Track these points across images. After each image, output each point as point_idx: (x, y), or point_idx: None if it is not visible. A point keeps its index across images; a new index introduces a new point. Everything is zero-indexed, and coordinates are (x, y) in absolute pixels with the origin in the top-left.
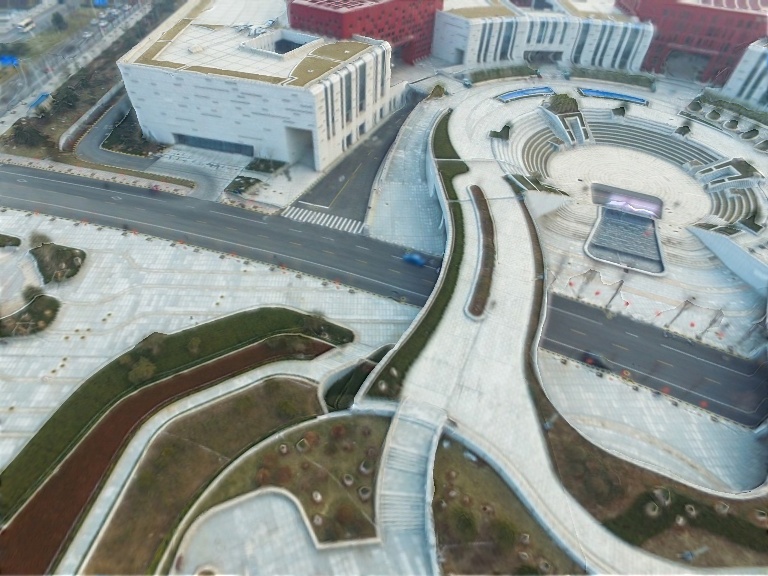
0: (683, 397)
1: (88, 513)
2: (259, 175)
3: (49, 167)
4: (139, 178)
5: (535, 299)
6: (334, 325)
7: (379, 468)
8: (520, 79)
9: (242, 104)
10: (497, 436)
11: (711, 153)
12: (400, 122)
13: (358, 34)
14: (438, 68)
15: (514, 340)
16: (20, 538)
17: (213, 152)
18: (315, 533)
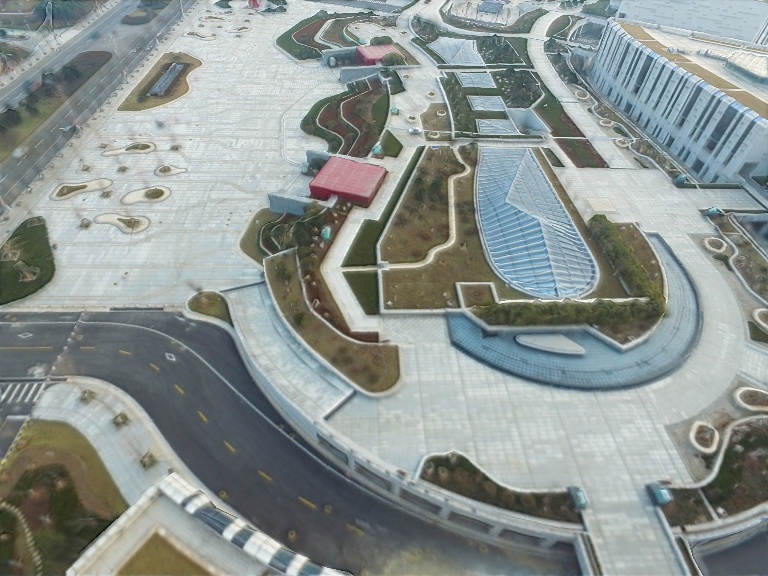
0: None
1: None
2: None
3: None
4: None
5: (446, 2)
6: (379, 15)
7: None
8: None
9: None
10: None
11: None
12: None
13: None
14: None
15: None
16: None
17: None
18: None
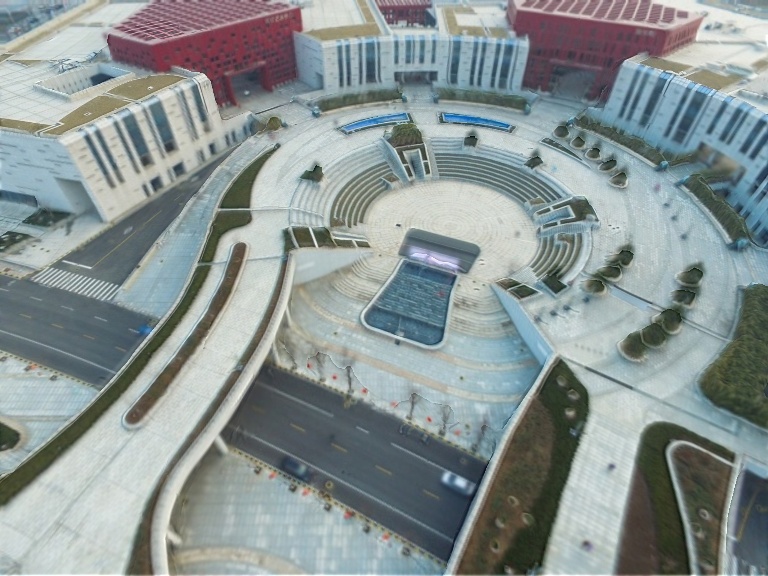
0: (382, 519)
1: None
2: (35, 229)
3: None
4: None
5: (216, 399)
6: (2, 426)
7: None
8: (381, 104)
9: (3, 154)
10: None
11: (557, 189)
12: None
13: (178, 66)
14: (298, 94)
15: (160, 457)
16: None
17: None
18: None
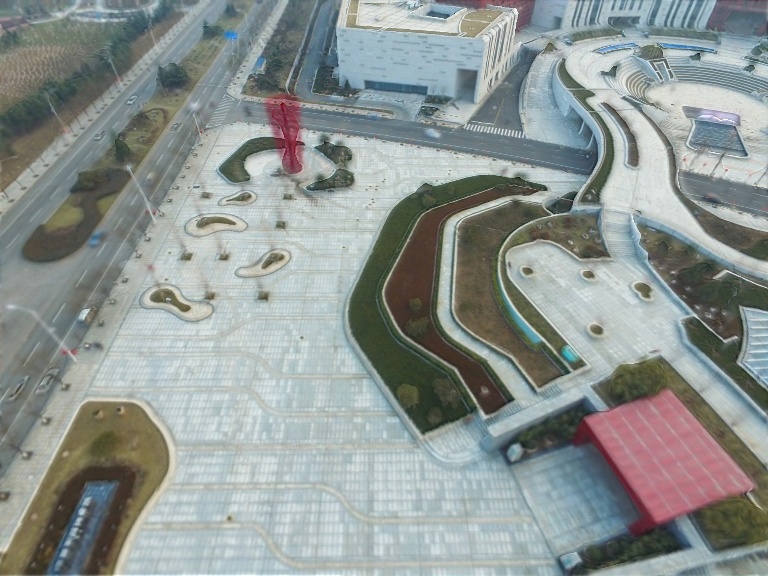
0: None
1: (441, 253)
2: (436, 106)
3: (289, 104)
4: (354, 109)
5: (670, 158)
6: (532, 182)
7: (602, 231)
8: (609, 38)
9: (428, 53)
10: (667, 218)
11: None
12: (520, 72)
13: (490, 4)
14: (540, 33)
15: (662, 178)
16: (410, 263)
17: (395, 93)
18: (577, 255)
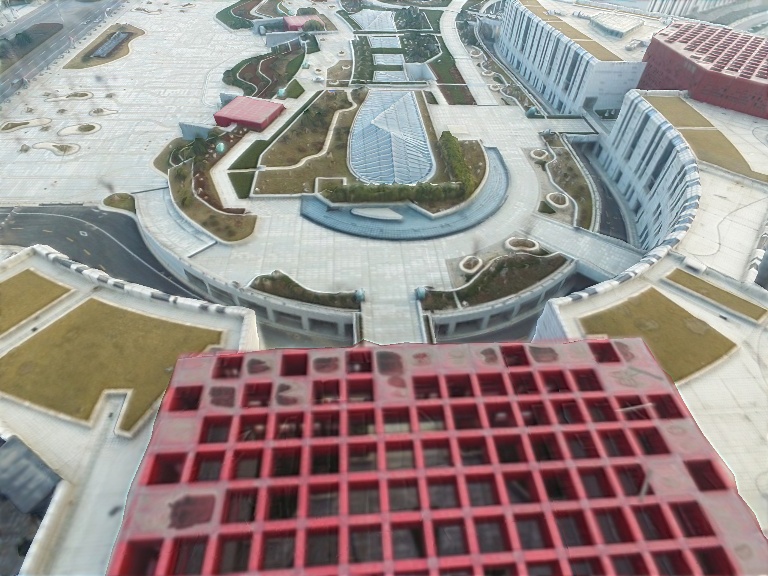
0: None
1: None
2: None
3: None
4: None
5: None
6: None
7: None
8: None
9: None
10: None
11: None
12: None
13: None
14: None
15: None
16: None
17: None
18: (313, 1)
